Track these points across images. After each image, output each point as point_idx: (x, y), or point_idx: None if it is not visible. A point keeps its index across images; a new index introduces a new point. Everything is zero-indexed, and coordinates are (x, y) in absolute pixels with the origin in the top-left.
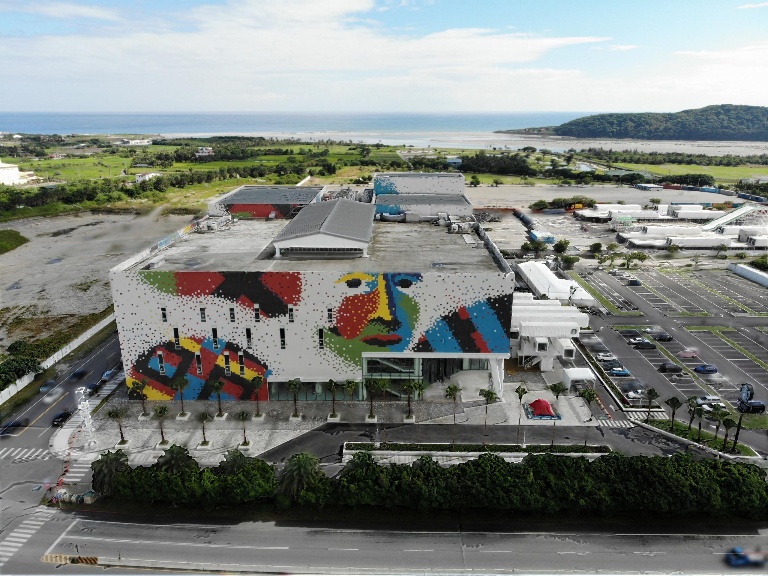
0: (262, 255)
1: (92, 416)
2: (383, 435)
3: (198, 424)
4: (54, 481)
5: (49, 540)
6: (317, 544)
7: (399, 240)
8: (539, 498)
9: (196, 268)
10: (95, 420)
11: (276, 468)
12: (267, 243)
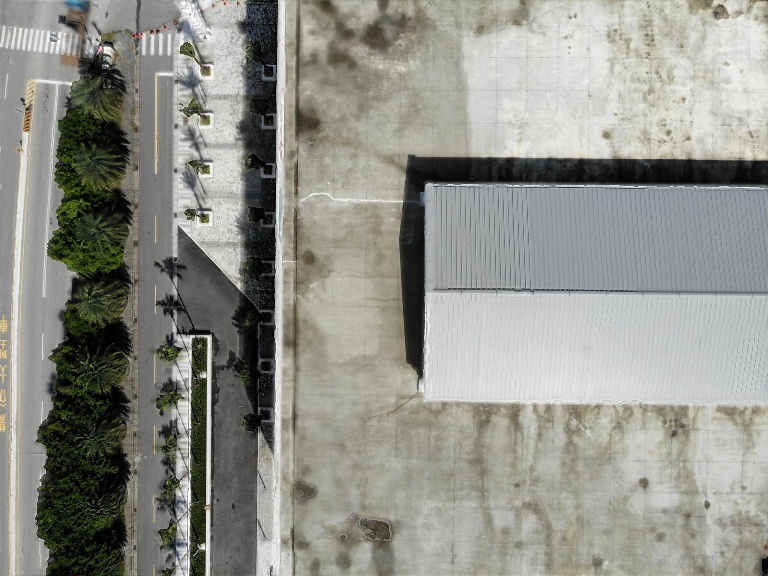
0: (444, 162)
1: (272, 1)
2: (231, 380)
3: (254, 146)
4: (141, 28)
5: (52, 74)
6: (49, 322)
7: (587, 459)
8: (45, 542)
9: (345, 54)
10: (264, 10)
11: (107, 271)
12: (551, 151)
